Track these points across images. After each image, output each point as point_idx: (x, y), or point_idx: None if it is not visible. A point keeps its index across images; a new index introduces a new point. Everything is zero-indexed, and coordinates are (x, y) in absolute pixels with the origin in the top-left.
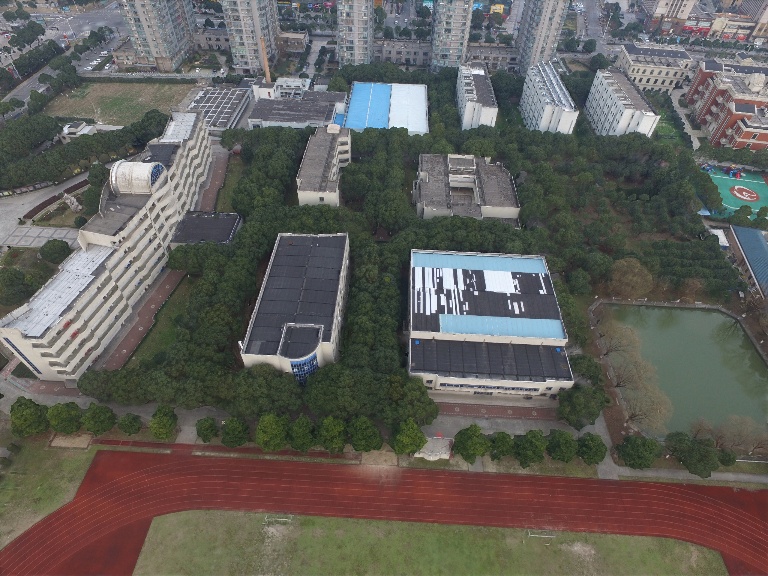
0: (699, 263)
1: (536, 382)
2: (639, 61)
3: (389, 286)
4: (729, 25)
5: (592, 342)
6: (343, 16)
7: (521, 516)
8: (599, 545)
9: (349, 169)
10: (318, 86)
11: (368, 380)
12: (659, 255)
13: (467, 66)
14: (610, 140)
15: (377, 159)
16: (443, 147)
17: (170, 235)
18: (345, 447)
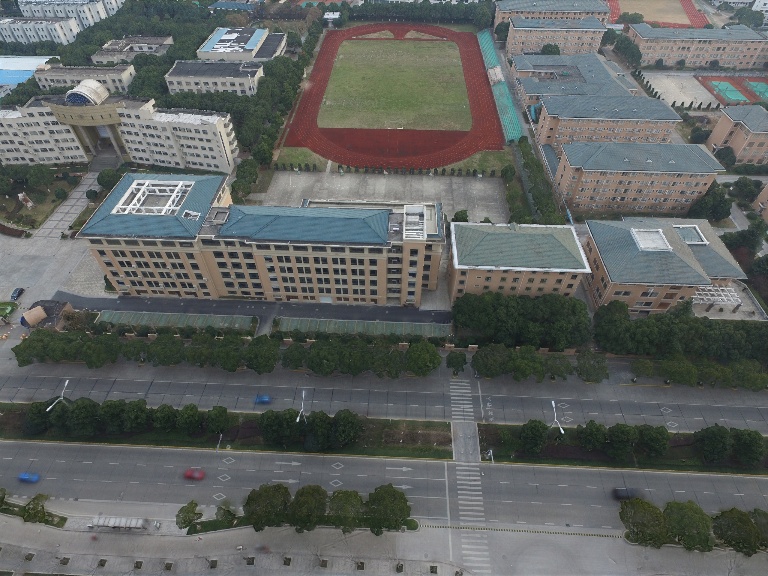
0: None
1: None
2: None
3: None
4: None
5: None
6: None
7: (330, 63)
8: None
9: None
10: None
11: None
12: None
13: None
14: (125, 9)
15: None
16: (93, 47)
17: None
18: None
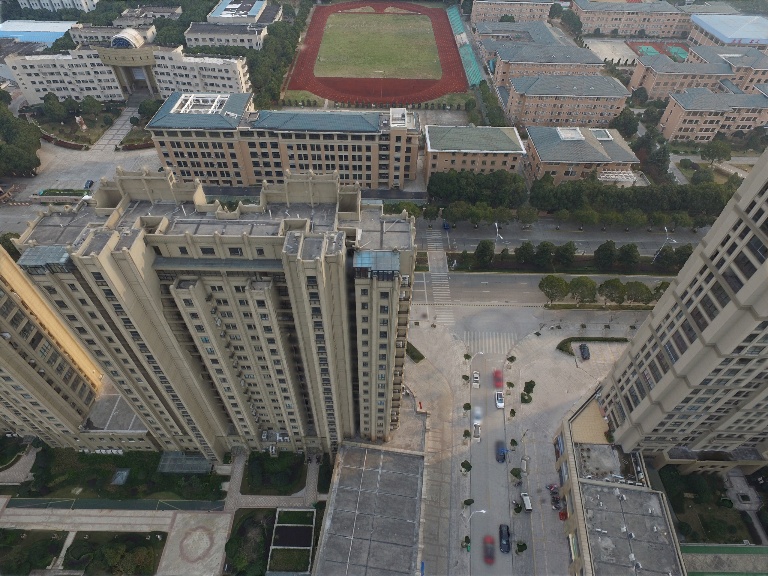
0: None
1: None
2: None
3: None
4: None
5: None
6: None
7: None
8: None
9: None
10: None
11: (276, 24)
12: None
13: None
14: None
15: None
16: (113, 13)
17: None
18: None
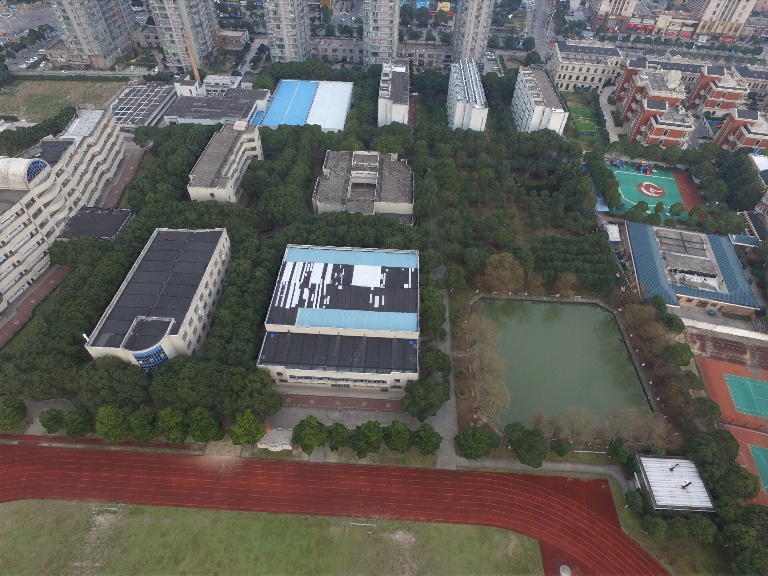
0: (582, 258)
1: (380, 374)
2: (569, 58)
3: (259, 280)
4: (673, 22)
5: (462, 336)
6: (270, 14)
7: (350, 505)
8: (421, 533)
9: (251, 165)
10: (245, 83)
11: (210, 372)
12: (545, 250)
13: (390, 63)
14: (520, 137)
15: (284, 156)
16: (350, 144)
17: (58, 231)
18: (192, 438)
